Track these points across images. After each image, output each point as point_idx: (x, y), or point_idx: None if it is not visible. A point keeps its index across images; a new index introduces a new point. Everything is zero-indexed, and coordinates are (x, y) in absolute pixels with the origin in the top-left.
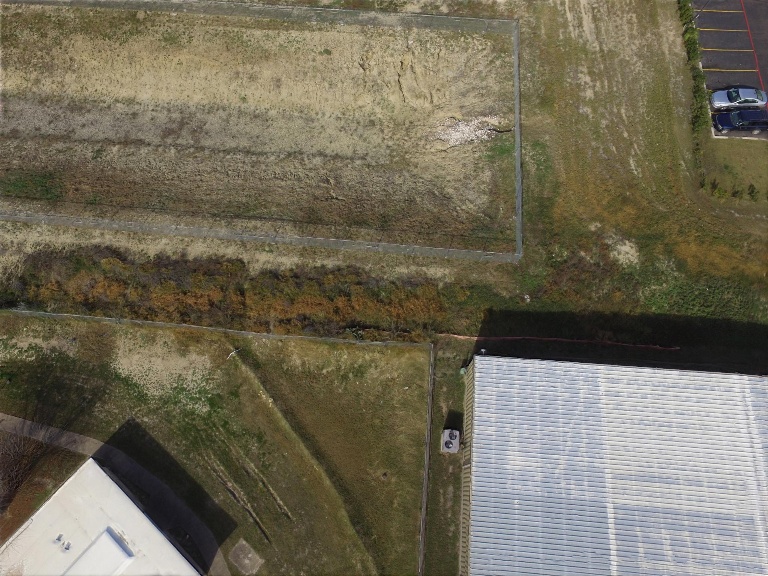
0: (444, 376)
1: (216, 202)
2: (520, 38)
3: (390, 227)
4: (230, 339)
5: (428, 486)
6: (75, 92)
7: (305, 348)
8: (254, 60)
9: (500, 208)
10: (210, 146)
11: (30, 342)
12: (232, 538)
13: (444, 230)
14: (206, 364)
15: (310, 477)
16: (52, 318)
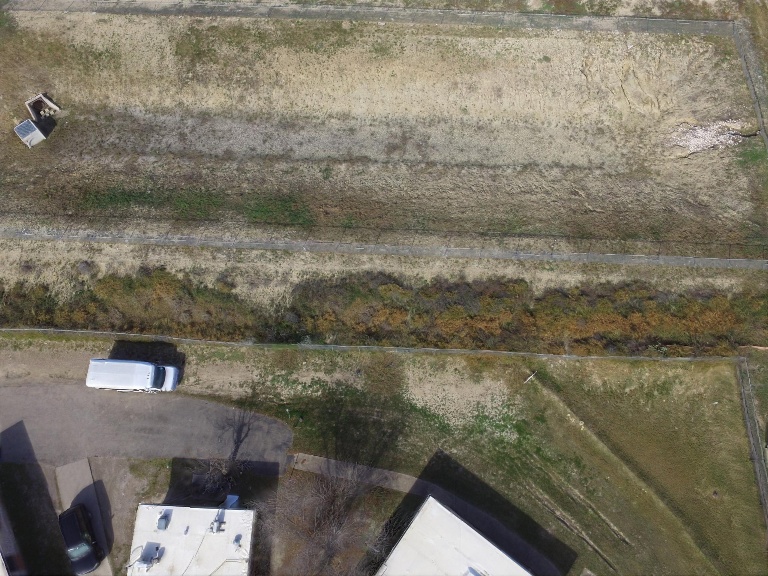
0: (753, 389)
1: (476, 220)
2: (741, 39)
3: (664, 239)
4: (526, 362)
5: (765, 502)
6: (285, 109)
7: (604, 368)
8: (472, 69)
9: (767, 214)
10: (441, 161)
11: (312, 376)
12: (575, 568)
13: (719, 239)
14: (503, 389)
15: (639, 500)
16: (333, 350)
